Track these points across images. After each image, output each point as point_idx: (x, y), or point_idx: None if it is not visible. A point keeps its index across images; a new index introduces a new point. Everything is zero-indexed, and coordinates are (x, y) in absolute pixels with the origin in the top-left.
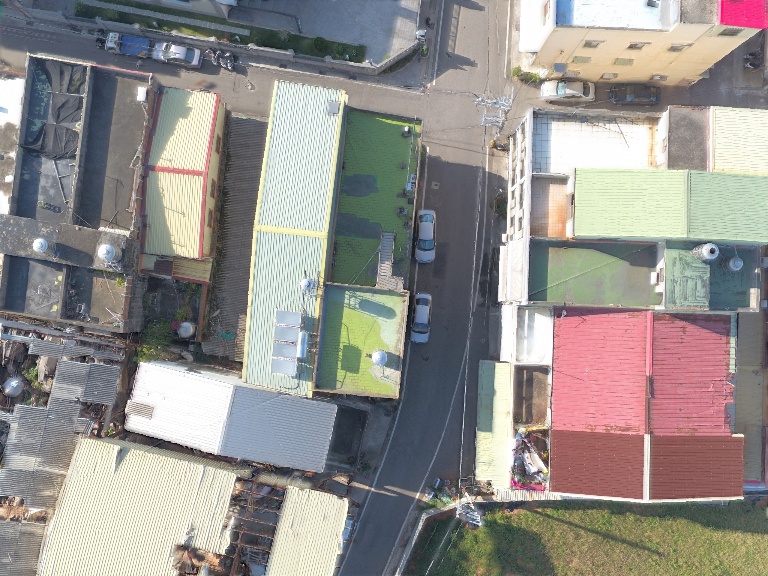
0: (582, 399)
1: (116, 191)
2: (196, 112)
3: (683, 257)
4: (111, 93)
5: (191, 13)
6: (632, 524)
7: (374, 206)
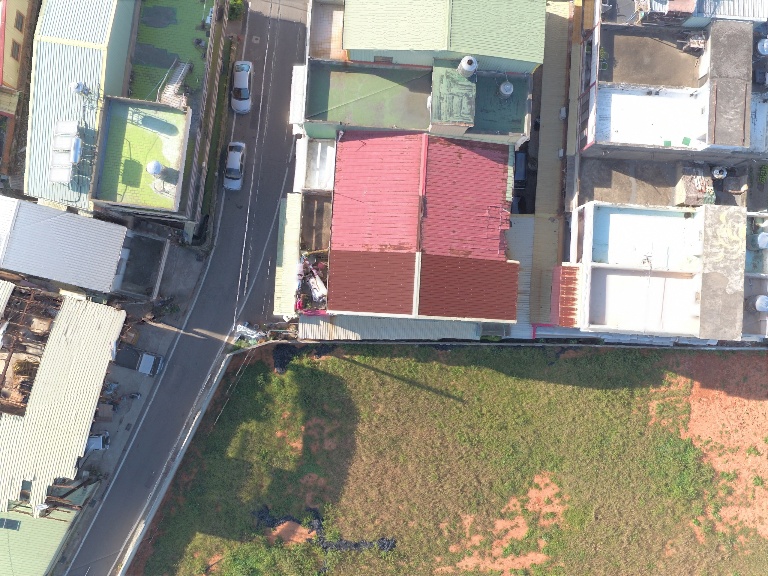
0: (360, 220)
1: None
2: None
3: (450, 75)
4: None
5: None
6: (438, 373)
7: (172, 37)
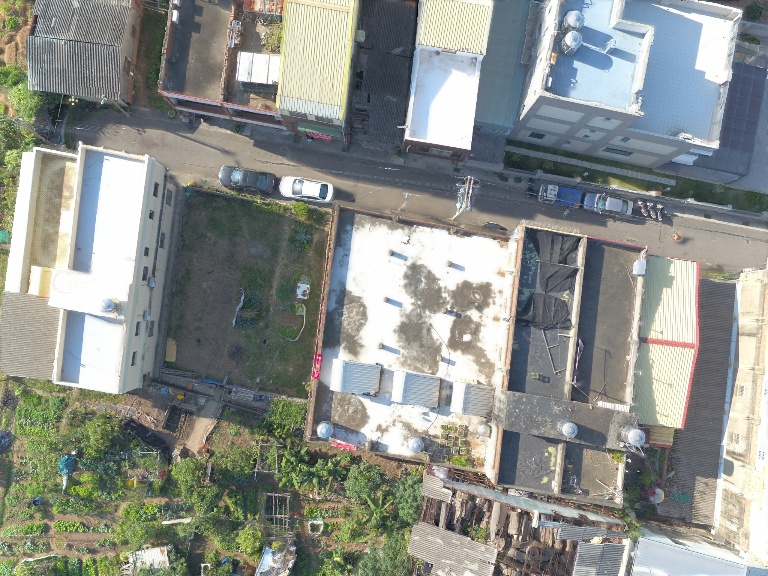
0: None
1: (605, 362)
2: (679, 281)
3: None
4: (598, 262)
5: (618, 163)
6: None
7: None
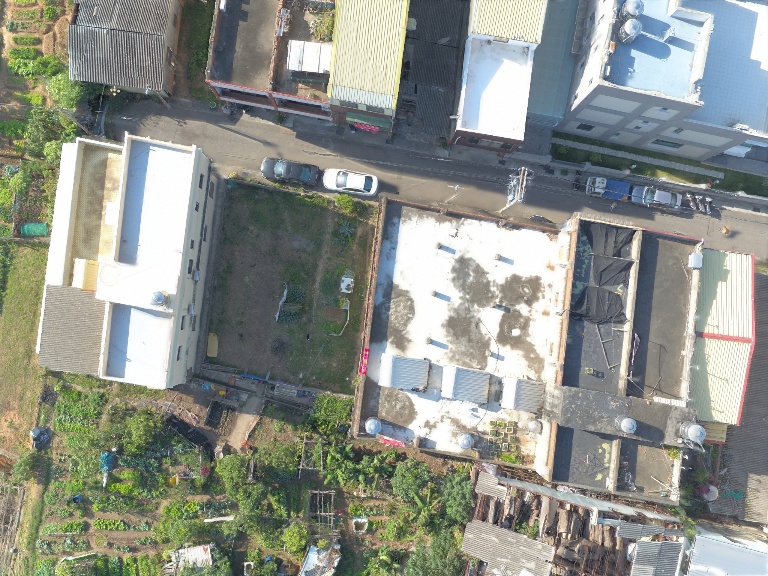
0: None
1: (659, 356)
2: (734, 275)
3: None
4: (653, 255)
5: (666, 155)
6: None
7: None
